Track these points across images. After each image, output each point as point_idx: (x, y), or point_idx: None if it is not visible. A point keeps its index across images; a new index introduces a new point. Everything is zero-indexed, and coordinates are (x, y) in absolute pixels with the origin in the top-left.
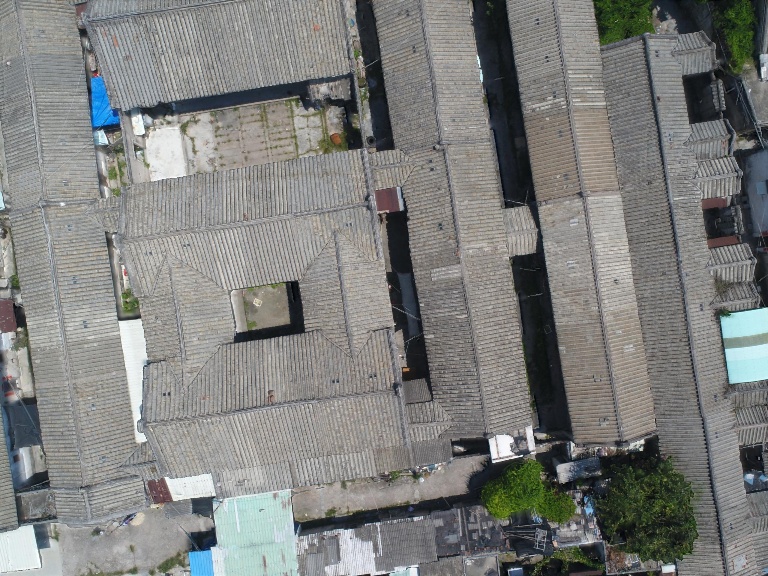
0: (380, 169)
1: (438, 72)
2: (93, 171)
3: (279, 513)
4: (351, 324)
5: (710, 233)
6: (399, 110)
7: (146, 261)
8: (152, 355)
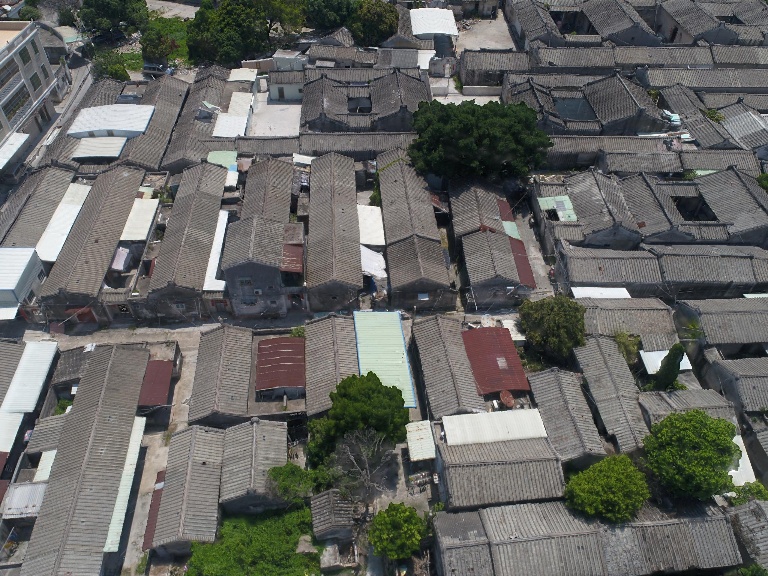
0: None
1: None
2: None
3: None
4: None
5: None
6: (641, 3)
7: None
8: (760, 37)
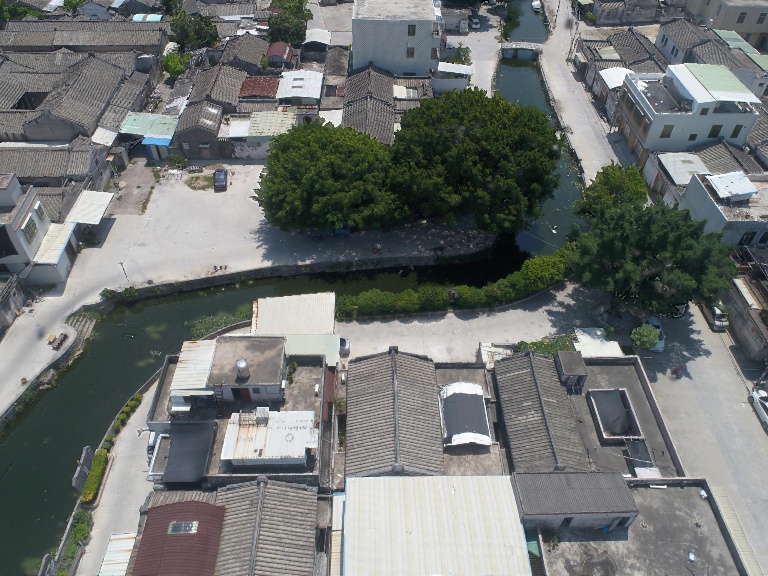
0: None
1: None
2: None
3: (140, 116)
4: None
5: None
6: None
7: None
8: (21, 130)
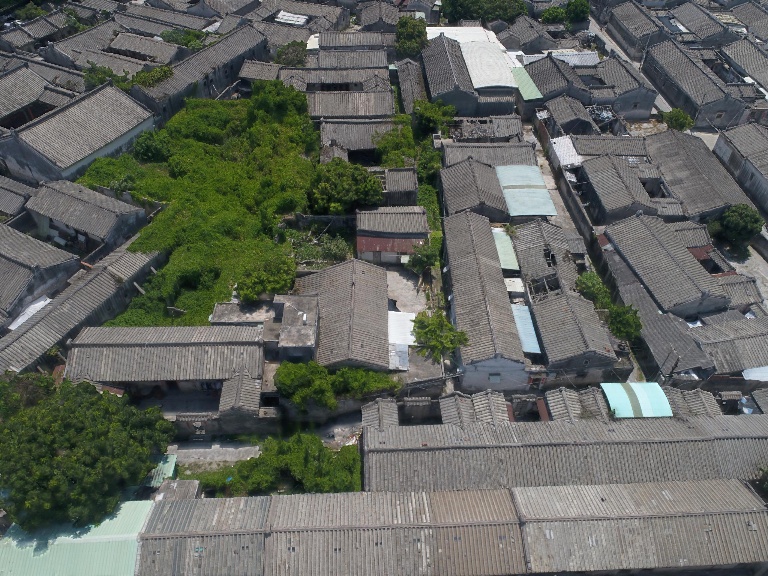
0: None
1: None
2: None
3: None
4: None
5: (528, 421)
6: None
7: None
8: None
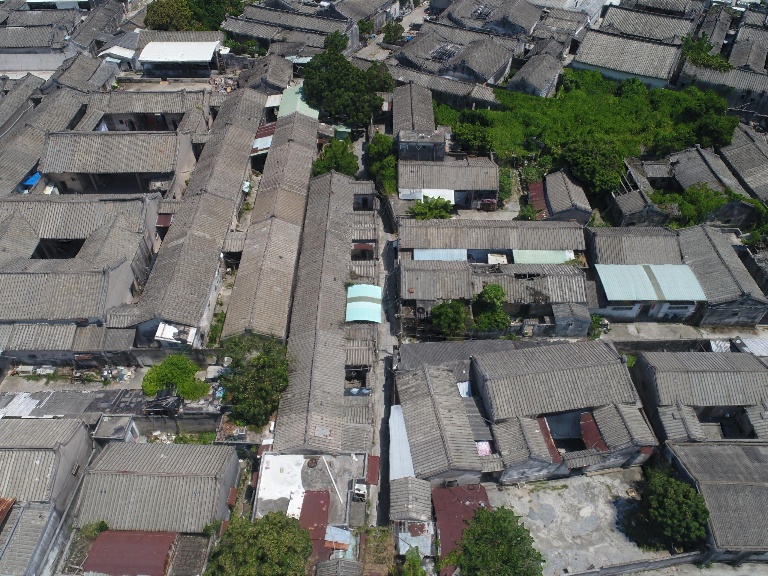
0: (165, 203)
1: (216, 172)
2: (7, 193)
3: None
4: (102, 251)
5: None
6: None
7: (2, 213)
8: None
